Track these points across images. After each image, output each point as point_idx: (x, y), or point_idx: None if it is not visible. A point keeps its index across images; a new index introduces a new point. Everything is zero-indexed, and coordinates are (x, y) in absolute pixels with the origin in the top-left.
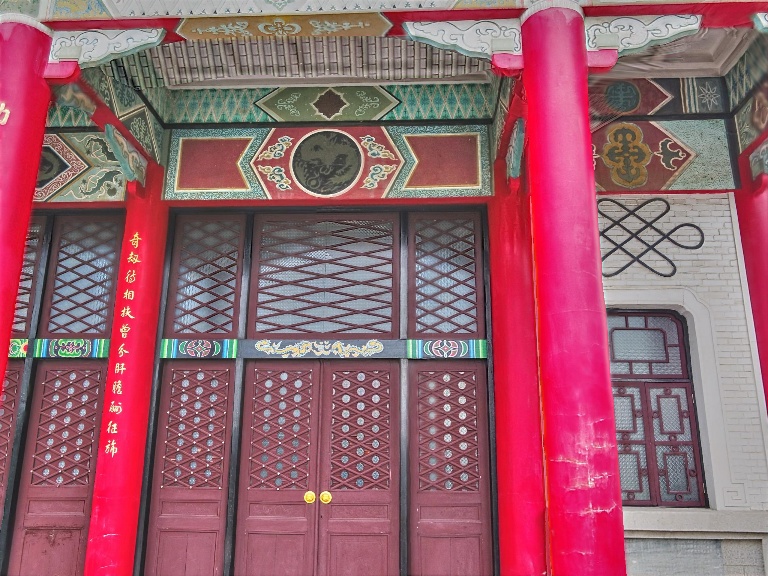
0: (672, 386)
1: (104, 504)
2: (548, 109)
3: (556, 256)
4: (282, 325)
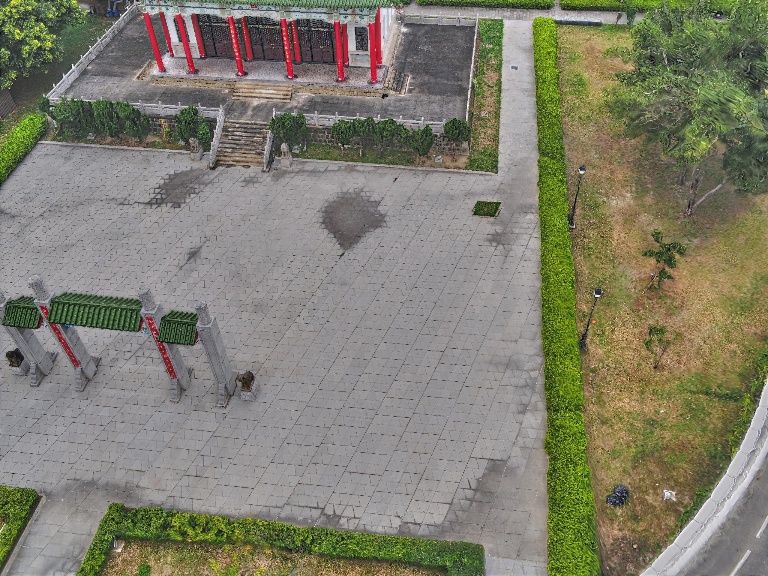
0: (365, 36)
1: (296, 49)
2: (336, 32)
3: (337, 46)
4: (314, 25)
